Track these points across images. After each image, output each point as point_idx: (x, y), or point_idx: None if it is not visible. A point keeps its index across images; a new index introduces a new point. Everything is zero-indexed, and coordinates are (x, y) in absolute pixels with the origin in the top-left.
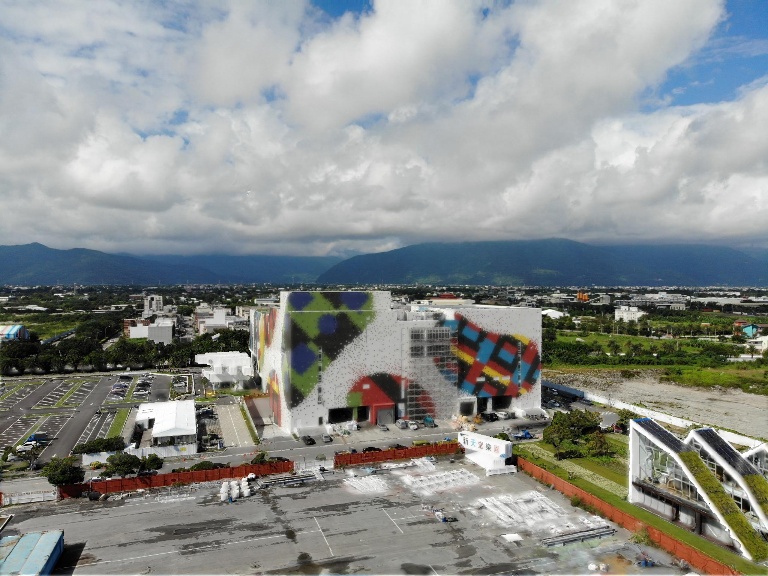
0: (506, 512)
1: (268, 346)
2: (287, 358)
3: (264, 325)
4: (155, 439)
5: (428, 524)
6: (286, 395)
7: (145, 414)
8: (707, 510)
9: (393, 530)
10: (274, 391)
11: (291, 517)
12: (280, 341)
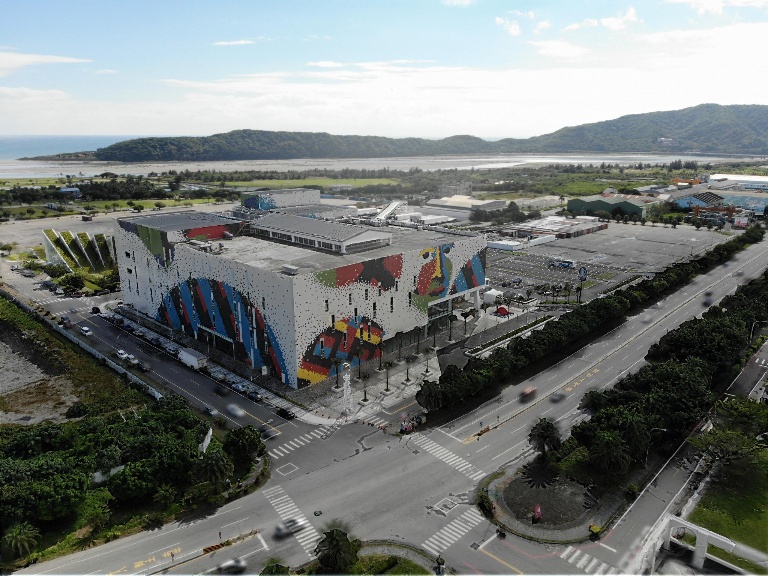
0: None
1: None
2: None
3: None
4: None
5: None
6: None
7: None
8: None
9: None
10: None
11: None
12: None
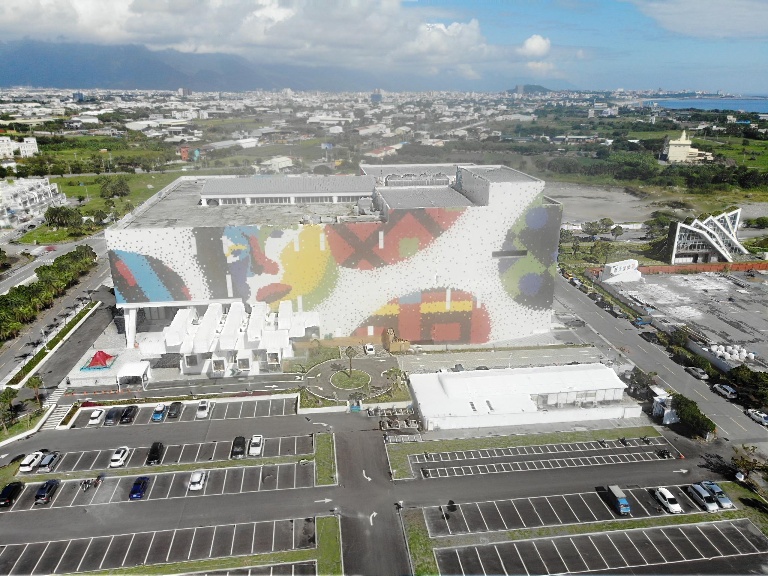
0: (715, 286)
1: (381, 266)
2: (542, 258)
3: (334, 240)
4: (623, 390)
5: (741, 305)
6: (531, 298)
7: (505, 405)
8: (711, 251)
9: (759, 313)
10: (440, 314)
11: (765, 337)
12: (494, 245)
